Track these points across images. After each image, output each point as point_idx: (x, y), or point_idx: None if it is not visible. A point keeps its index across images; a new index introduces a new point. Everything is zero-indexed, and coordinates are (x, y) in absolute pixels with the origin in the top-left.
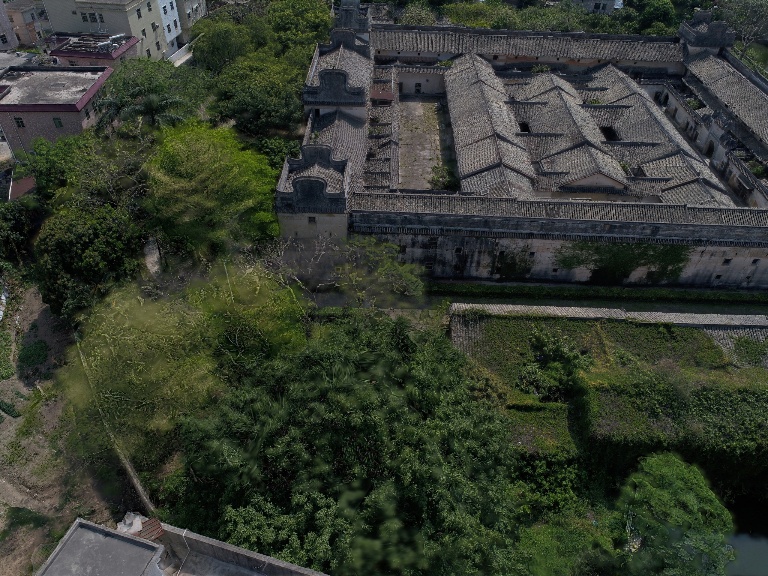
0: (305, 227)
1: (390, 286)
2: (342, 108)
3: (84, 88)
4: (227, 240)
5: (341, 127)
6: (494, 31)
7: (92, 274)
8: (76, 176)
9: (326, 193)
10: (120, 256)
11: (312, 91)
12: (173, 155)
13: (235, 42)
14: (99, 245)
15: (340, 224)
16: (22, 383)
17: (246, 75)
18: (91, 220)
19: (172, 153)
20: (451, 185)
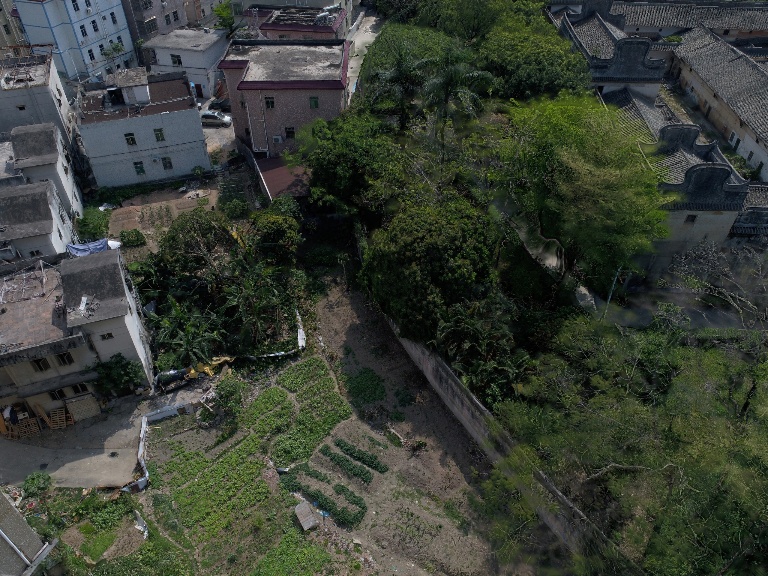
0: (677, 228)
1: (761, 301)
2: (631, 85)
3: (331, 63)
4: (623, 245)
5: (641, 107)
6: (719, 3)
7: (462, 288)
8: (368, 165)
9: (725, 185)
10: (486, 265)
11: (602, 65)
12: (578, 135)
13: (492, 9)
14: (469, 251)
15: (724, 224)
16: (367, 425)
17: (520, 46)
18: (456, 219)
19: (576, 132)
20: (754, 177)
